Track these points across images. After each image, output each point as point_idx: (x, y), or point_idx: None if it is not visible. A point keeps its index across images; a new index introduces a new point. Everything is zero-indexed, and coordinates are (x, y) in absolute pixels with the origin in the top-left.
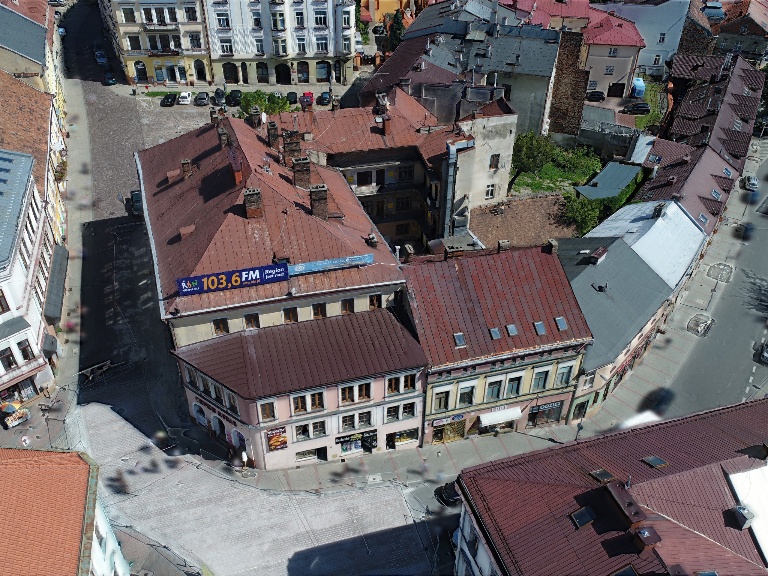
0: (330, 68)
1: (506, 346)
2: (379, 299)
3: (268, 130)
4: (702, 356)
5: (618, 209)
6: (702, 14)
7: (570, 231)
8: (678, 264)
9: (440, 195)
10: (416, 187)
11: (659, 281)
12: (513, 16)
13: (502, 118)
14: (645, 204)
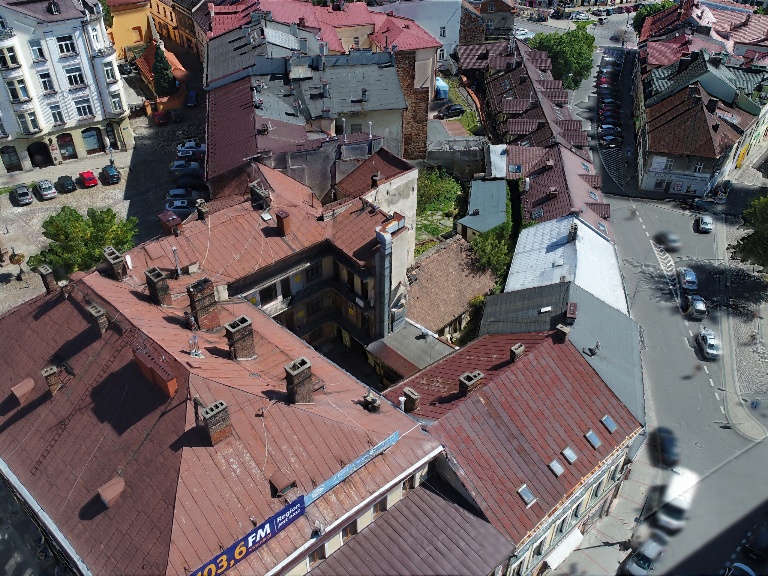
0: (101, 134)
1: (573, 479)
2: (411, 480)
3: (151, 283)
4: (658, 372)
5: (516, 236)
6: (463, 0)
7: (488, 277)
8: (615, 287)
9: (375, 292)
10: (329, 284)
11: (624, 318)
12: (314, 38)
13: (403, 177)
14: (544, 226)
